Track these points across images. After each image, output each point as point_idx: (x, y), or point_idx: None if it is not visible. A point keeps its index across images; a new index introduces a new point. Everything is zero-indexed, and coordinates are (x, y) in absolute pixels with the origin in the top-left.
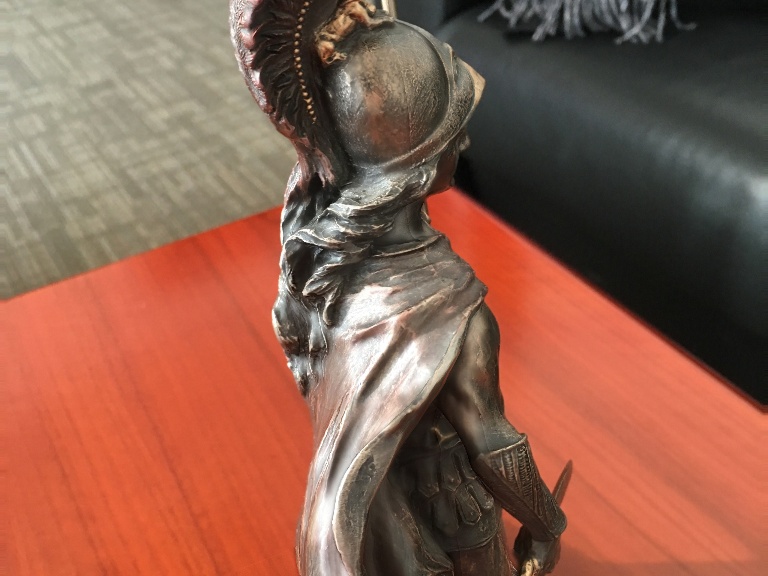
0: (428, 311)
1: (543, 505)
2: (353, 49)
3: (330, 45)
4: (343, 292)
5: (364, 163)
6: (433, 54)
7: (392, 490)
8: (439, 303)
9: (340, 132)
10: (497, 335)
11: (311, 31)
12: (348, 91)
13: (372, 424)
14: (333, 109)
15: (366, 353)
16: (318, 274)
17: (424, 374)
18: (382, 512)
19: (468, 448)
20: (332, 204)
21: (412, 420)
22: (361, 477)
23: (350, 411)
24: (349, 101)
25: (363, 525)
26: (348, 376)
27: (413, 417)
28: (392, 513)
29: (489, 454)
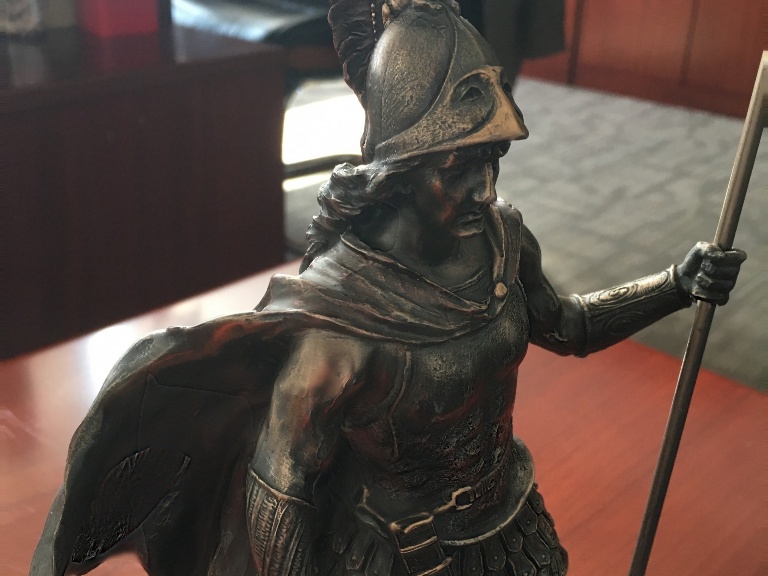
0: (287, 287)
1: None
2: None
3: (386, 9)
4: (318, 253)
5: None
6: (443, 57)
7: None
8: (297, 288)
9: None
10: (339, 381)
11: None
12: None
13: None
14: None
15: None
16: None
17: None
18: None
19: None
20: None
21: (185, 341)
22: (141, 348)
23: None
24: None
25: (117, 382)
26: None
27: (185, 338)
28: None
29: None
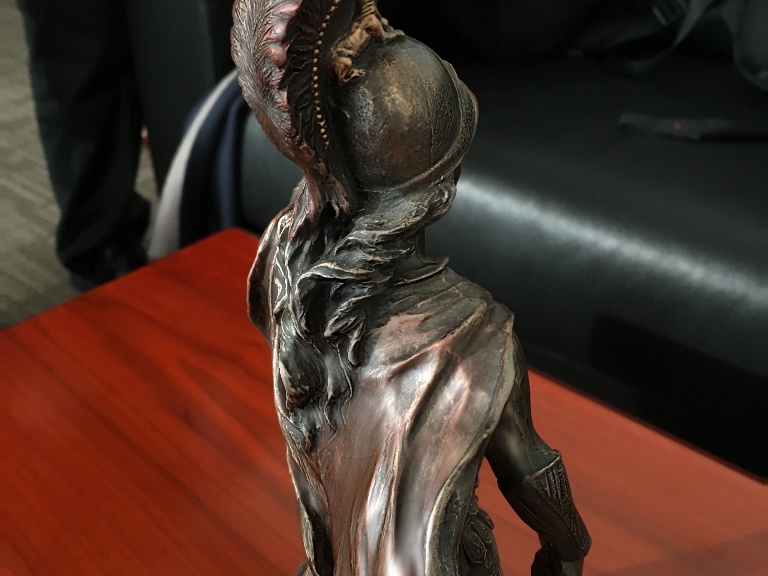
0: (470, 332)
1: (576, 521)
2: (371, 64)
3: (349, 61)
4: (367, 327)
5: (378, 187)
6: (443, 67)
7: None
8: (479, 322)
9: (354, 155)
10: None
11: (328, 47)
12: (370, 109)
13: (433, 460)
14: (349, 130)
15: (406, 387)
16: (343, 310)
17: (481, 397)
18: None
19: (512, 473)
20: (352, 233)
21: (485, 446)
22: (448, 516)
23: (402, 452)
24: (371, 119)
25: (457, 568)
26: (388, 416)
27: (486, 442)
28: None
29: (534, 475)
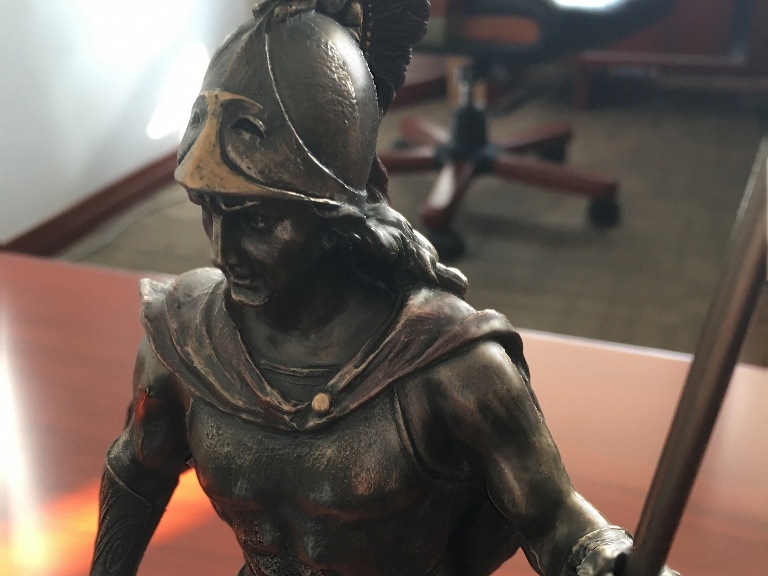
0: None
1: None
2: None
3: None
4: None
5: None
6: (209, 68)
7: None
8: None
9: None
10: None
11: None
12: None
13: None
14: None
15: None
16: None
17: None
18: None
19: None
20: None
21: None
22: None
23: None
24: None
25: None
26: None
27: None
28: None
29: None
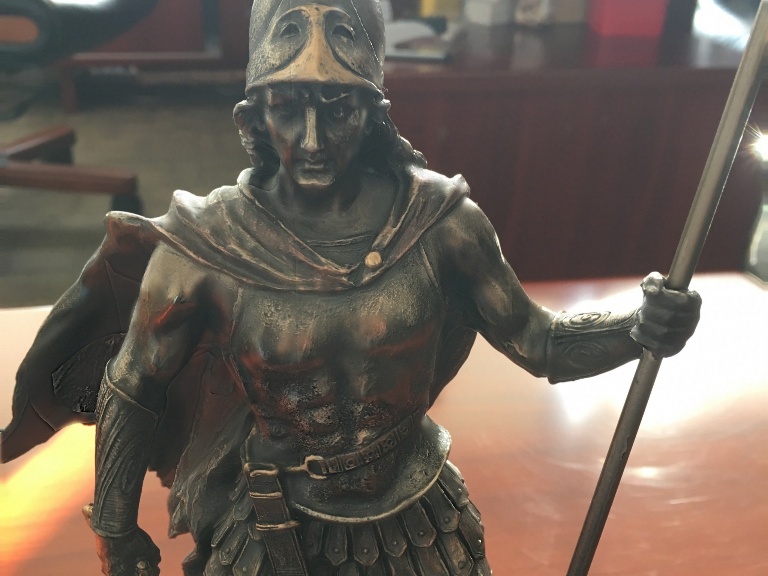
0: None
1: None
2: None
3: None
4: None
5: None
6: None
7: (240, 429)
8: None
9: None
10: (167, 295)
11: None
12: None
13: None
14: None
15: None
16: None
17: None
18: (227, 426)
19: None
20: None
21: None
22: None
23: None
24: None
25: None
26: None
27: None
28: (225, 437)
29: None
